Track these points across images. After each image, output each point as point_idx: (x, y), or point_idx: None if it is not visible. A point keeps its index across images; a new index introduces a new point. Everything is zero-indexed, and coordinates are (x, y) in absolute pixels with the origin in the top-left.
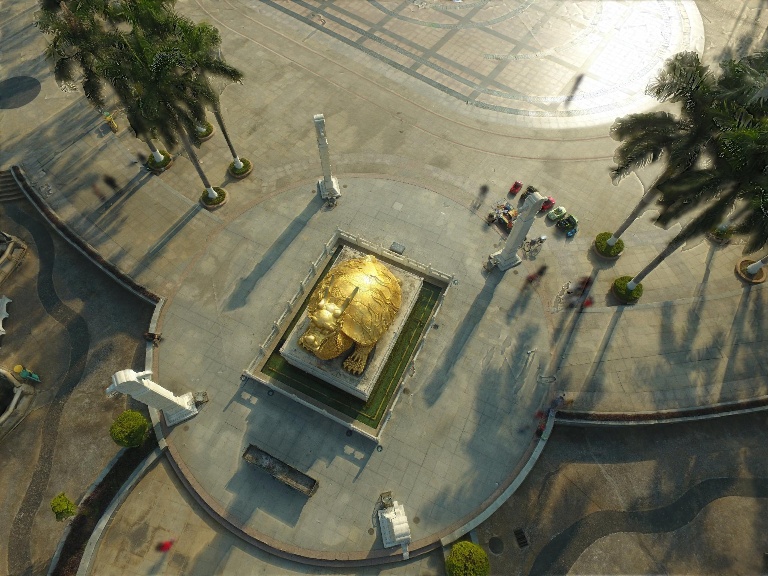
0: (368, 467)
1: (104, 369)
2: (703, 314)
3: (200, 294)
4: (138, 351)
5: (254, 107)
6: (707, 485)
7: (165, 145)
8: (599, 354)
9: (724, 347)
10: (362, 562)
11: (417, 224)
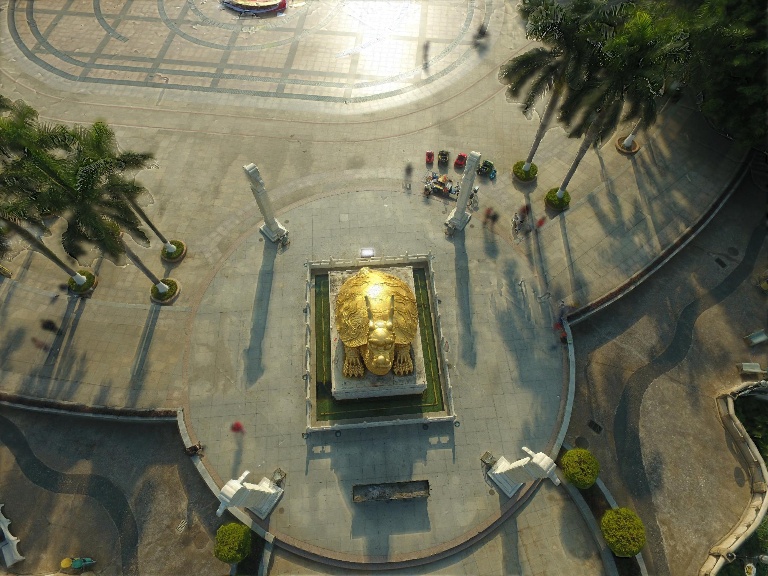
0: (458, 444)
1: (157, 509)
2: (617, 192)
3: (213, 386)
4: (181, 473)
5: (148, 188)
6: (686, 313)
7: (113, 259)
8: (568, 258)
9: (643, 209)
10: (499, 521)
11: (370, 225)
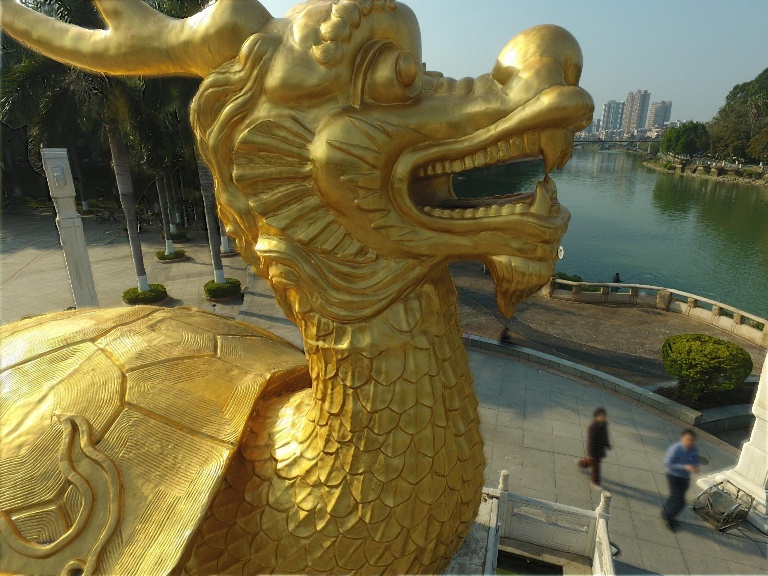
0: (685, 574)
1: None
2: None
3: None
4: None
5: None
6: None
7: None
8: None
9: None
10: None
11: None
